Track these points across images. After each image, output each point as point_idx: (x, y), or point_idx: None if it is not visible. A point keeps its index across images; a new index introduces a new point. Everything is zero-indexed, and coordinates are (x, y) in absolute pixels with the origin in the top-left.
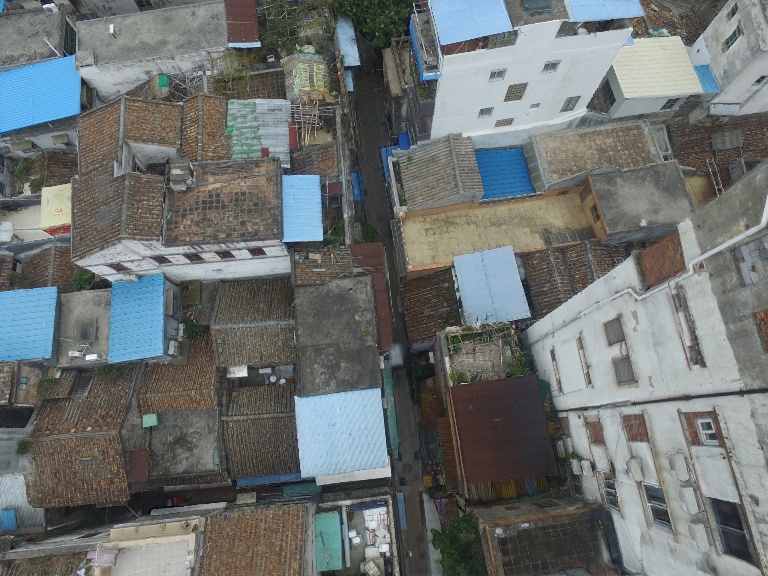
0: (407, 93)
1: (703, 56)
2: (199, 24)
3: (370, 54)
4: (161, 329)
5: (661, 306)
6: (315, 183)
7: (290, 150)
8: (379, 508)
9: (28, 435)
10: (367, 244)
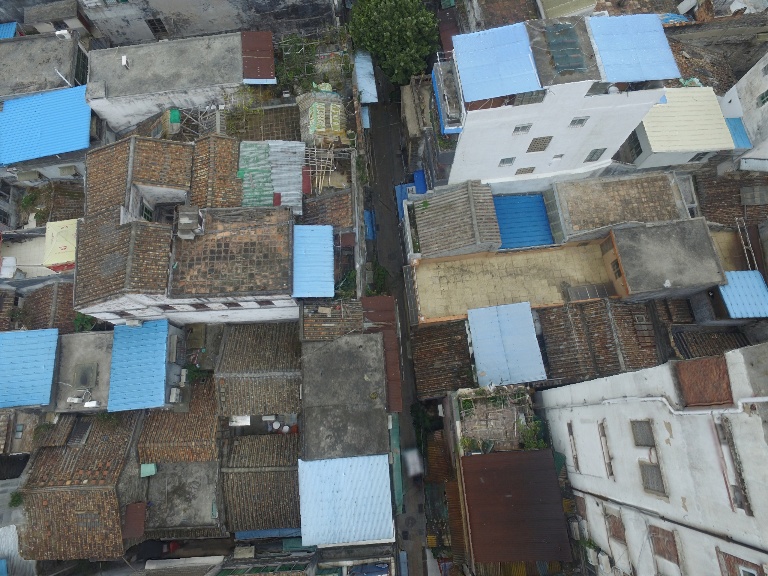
0: (425, 135)
1: (735, 108)
2: (214, 57)
3: (387, 82)
4: (163, 378)
5: (701, 430)
6: (328, 234)
7: (303, 196)
8: None
9: (22, 486)
10: (379, 297)
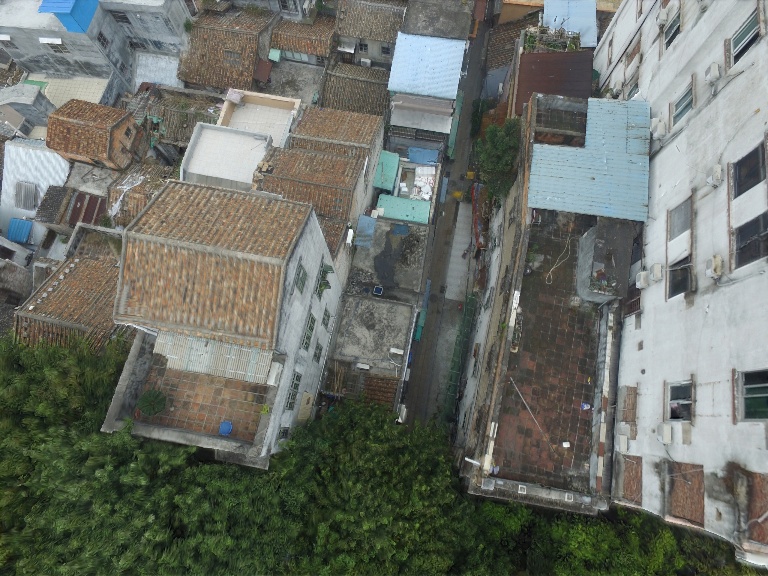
0: None
1: None
2: None
3: None
4: None
5: None
6: None
7: None
8: (429, 171)
9: (192, 21)
10: None
